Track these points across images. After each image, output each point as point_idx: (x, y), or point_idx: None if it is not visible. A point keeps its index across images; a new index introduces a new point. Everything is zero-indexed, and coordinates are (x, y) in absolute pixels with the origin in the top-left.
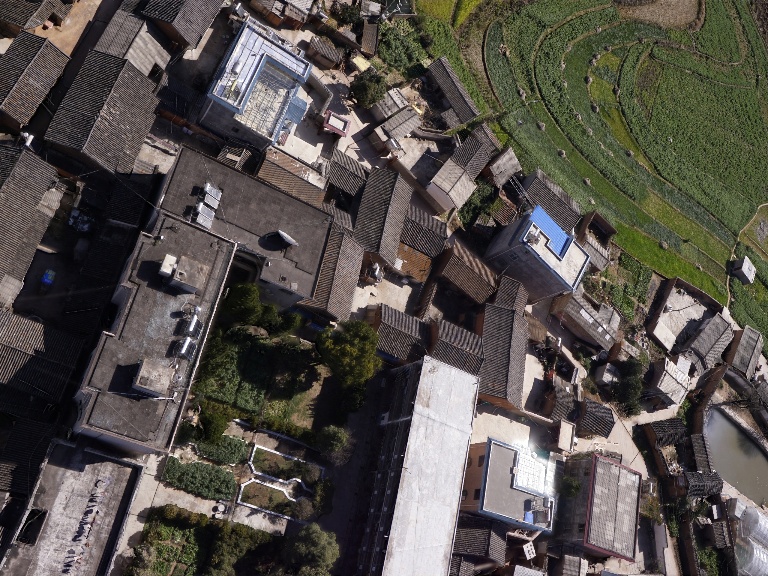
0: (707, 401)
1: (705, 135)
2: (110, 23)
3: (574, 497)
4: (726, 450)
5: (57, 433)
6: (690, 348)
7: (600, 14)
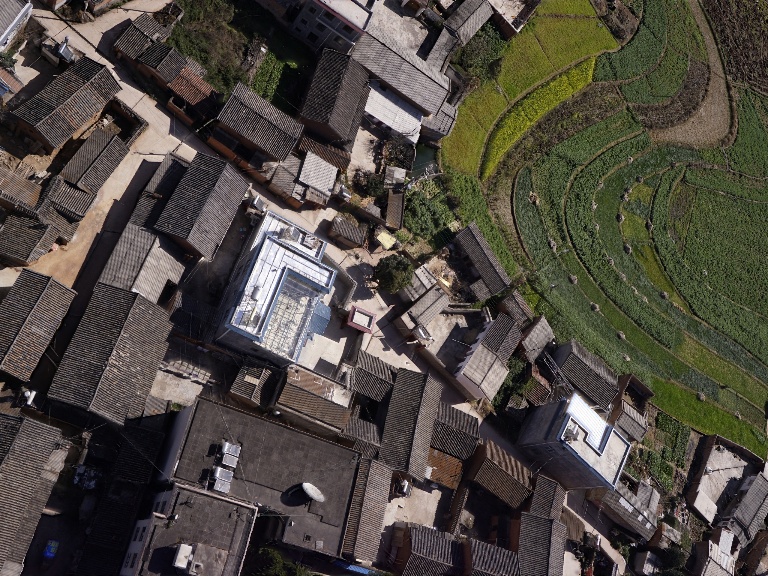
0: None
1: (740, 262)
2: (120, 240)
3: None
4: None
5: None
6: (732, 517)
7: (631, 143)
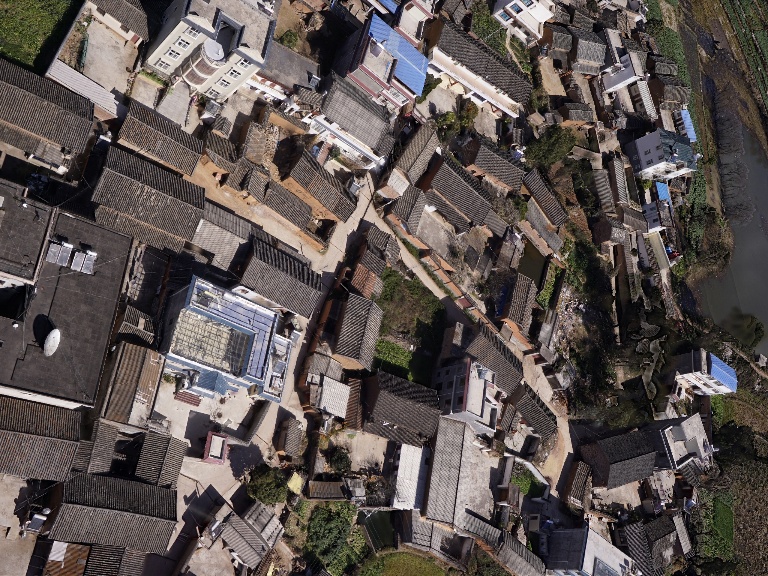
0: None
1: None
2: (236, 217)
3: None
4: None
5: None
6: None
7: None
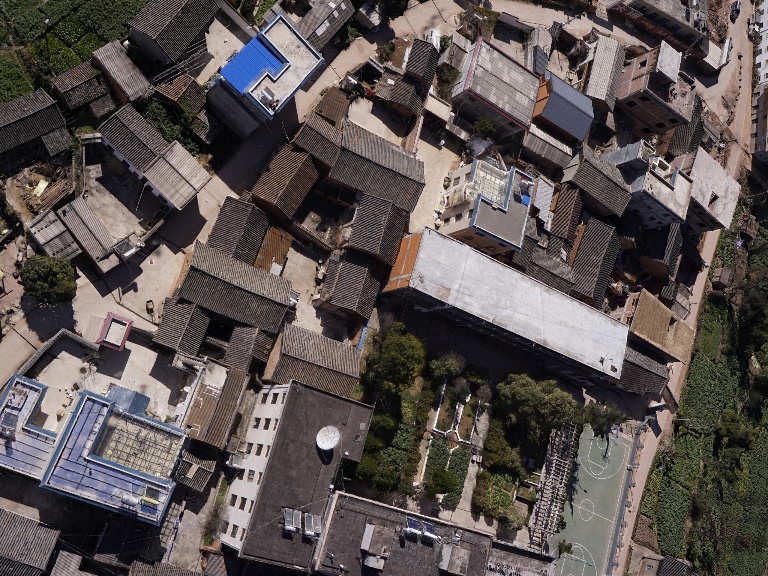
0: None
1: None
2: None
3: (482, 116)
4: None
5: None
6: None
7: None
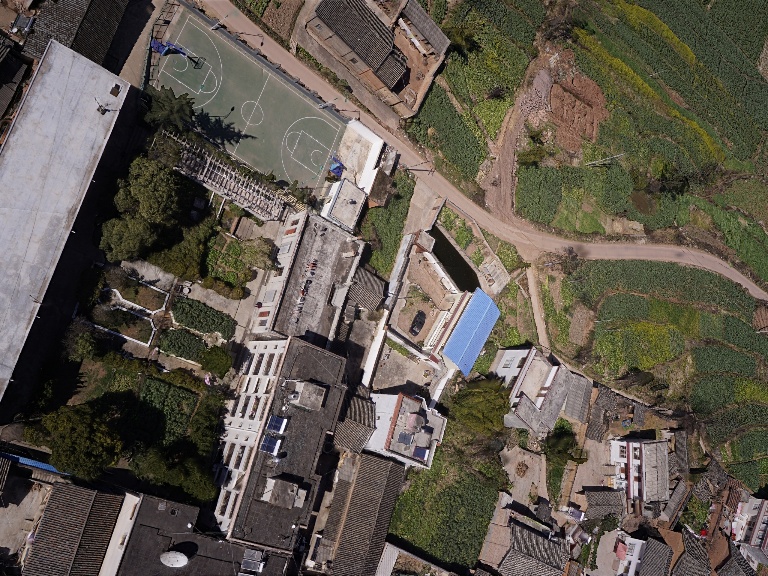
0: None
1: None
2: None
3: None
4: None
5: None
6: None
7: None
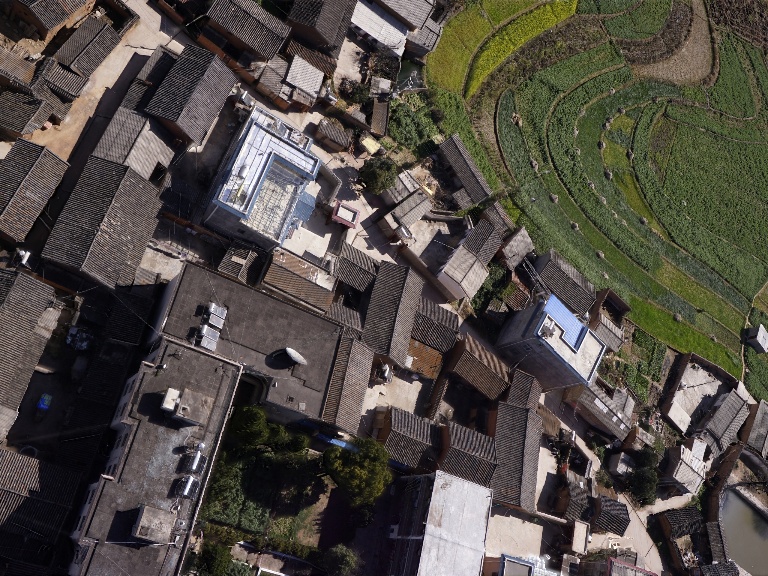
0: (722, 485)
1: (719, 196)
2: (111, 122)
3: None
4: (741, 534)
5: (52, 575)
6: (705, 429)
7: (614, 75)
